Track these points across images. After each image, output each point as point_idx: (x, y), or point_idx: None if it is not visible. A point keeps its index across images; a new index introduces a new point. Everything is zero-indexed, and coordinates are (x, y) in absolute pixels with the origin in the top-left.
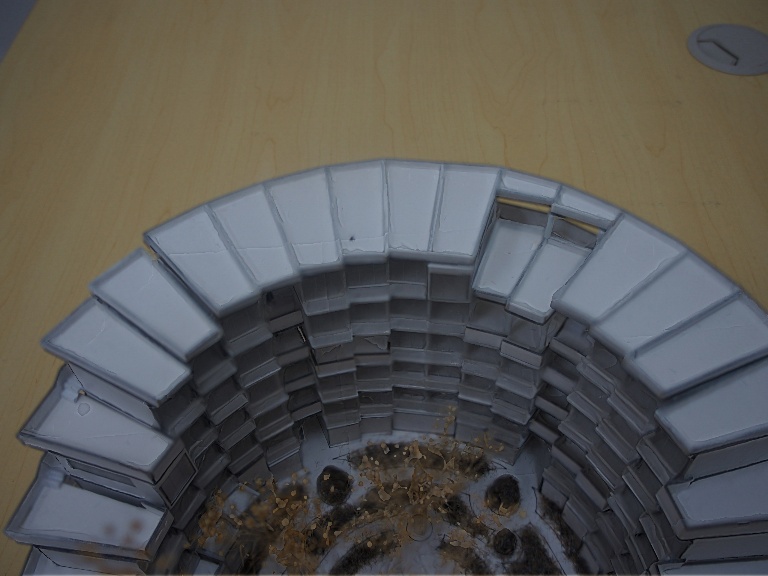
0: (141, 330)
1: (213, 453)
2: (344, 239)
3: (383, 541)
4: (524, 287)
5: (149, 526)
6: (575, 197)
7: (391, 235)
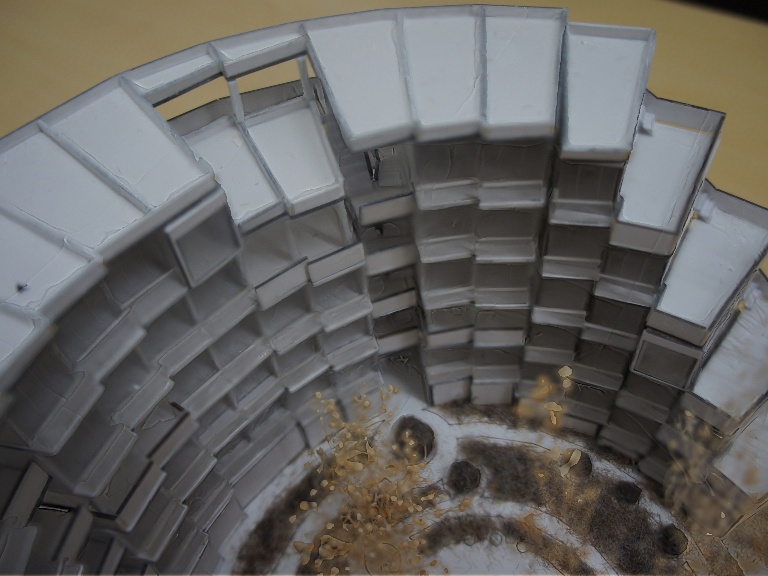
0: None
1: None
2: (8, 297)
3: None
4: (280, 182)
5: None
6: (235, 47)
7: (74, 236)
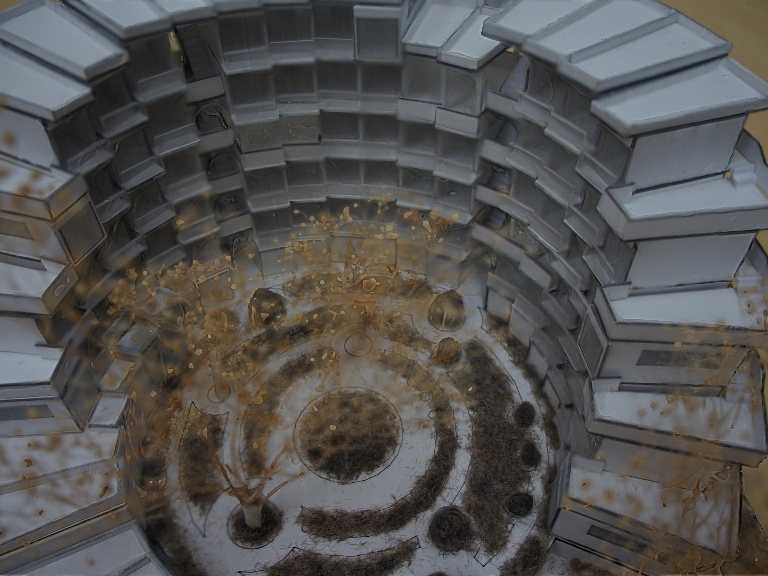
0: (38, 58)
1: (128, 239)
2: None
3: (319, 357)
4: (457, 44)
5: None
6: None
7: None
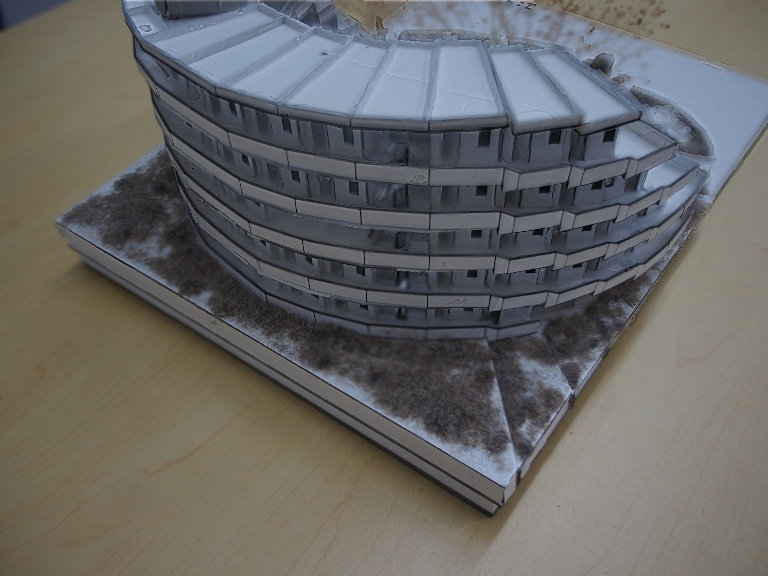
0: None
1: None
2: (332, 55)
3: None
4: None
5: None
6: (128, 8)
7: None
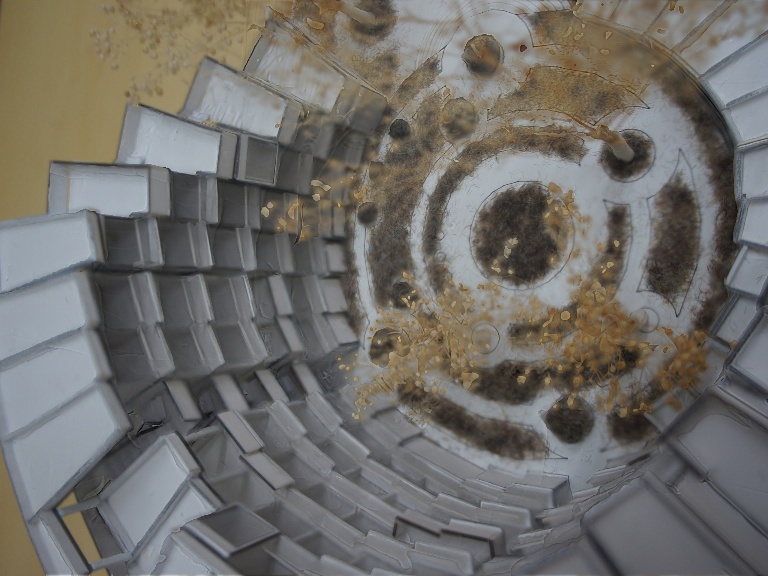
0: None
1: None
2: None
3: None
4: None
5: (767, 361)
6: None
7: None
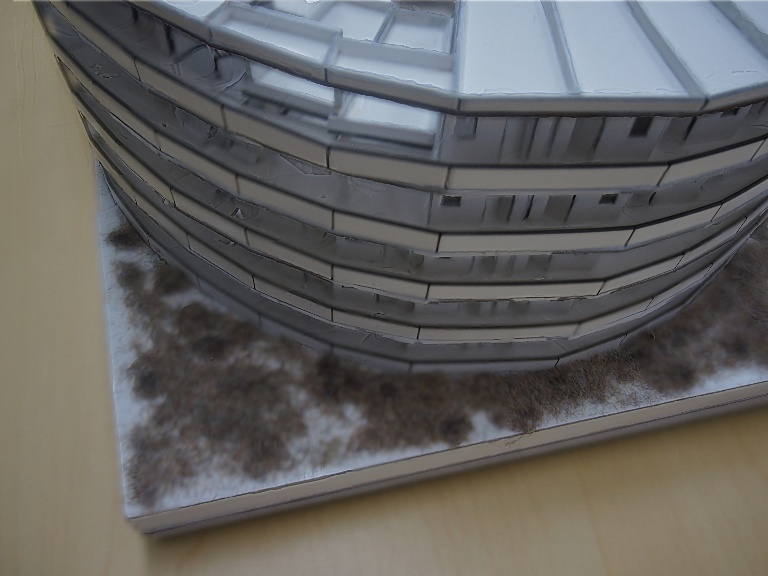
0: None
1: None
2: None
3: None
4: None
5: None
6: None
7: None
